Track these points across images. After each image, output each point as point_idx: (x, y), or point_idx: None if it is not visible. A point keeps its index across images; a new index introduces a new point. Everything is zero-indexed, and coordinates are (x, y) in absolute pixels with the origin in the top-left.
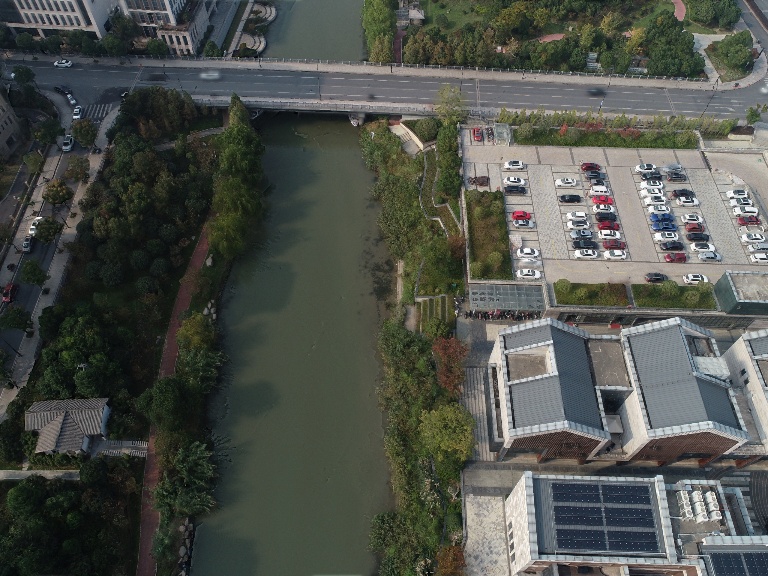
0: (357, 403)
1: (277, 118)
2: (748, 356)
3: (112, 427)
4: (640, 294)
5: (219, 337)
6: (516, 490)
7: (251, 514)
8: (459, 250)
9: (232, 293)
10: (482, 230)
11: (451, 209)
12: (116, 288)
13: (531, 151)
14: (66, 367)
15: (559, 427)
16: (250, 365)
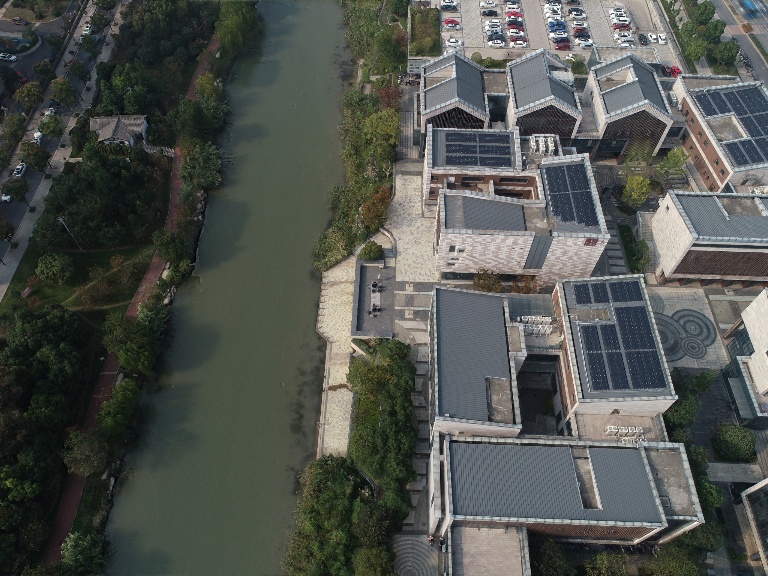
0: (324, 136)
1: None
2: (593, 79)
3: (150, 132)
4: None
5: (225, 99)
6: (425, 150)
7: (247, 191)
8: (403, 40)
9: (235, 77)
10: (421, 30)
11: (401, 25)
12: (149, 67)
13: None
14: (118, 93)
15: (453, 102)
16: (247, 115)
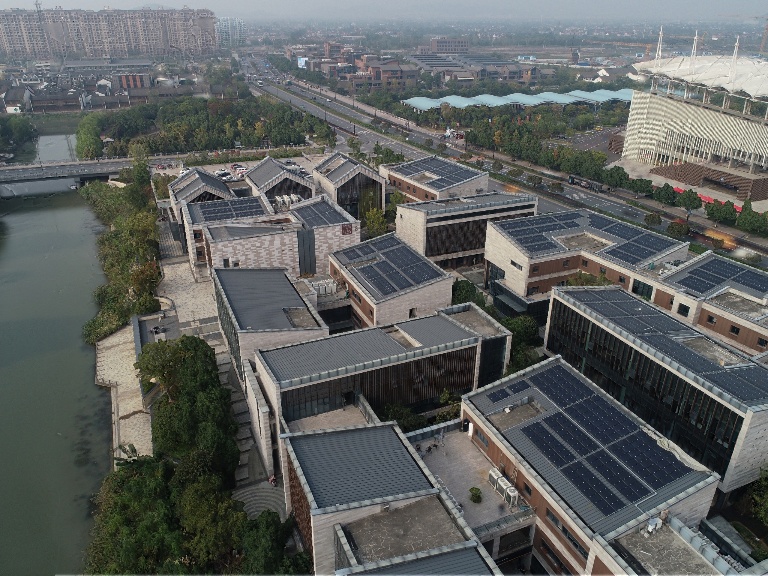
0: (82, 266)
1: (10, 200)
2: None
3: None
4: None
5: None
6: None
7: None
8: (149, 194)
9: None
10: None
11: None
12: None
13: None
14: None
15: (200, 186)
16: None
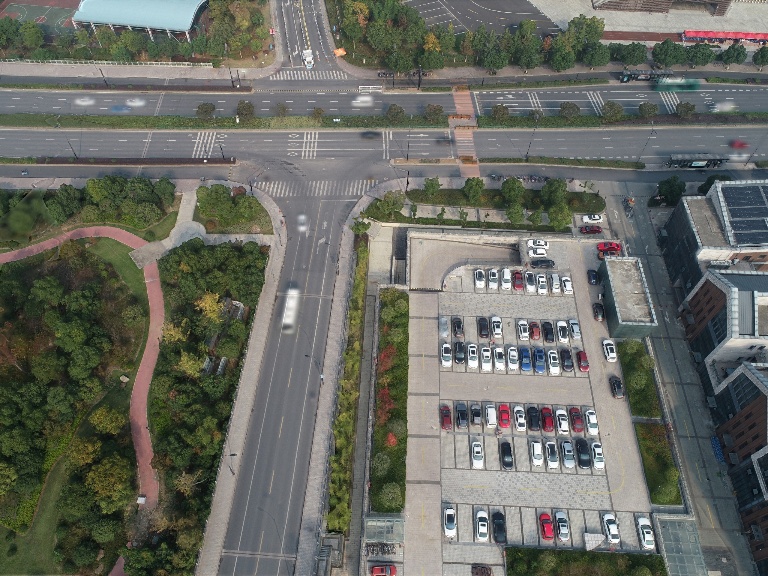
0: None
1: None
2: None
3: None
4: (647, 410)
5: None
6: None
7: None
8: None
9: None
10: None
11: None
12: None
13: (415, 491)
14: None
15: None
16: None
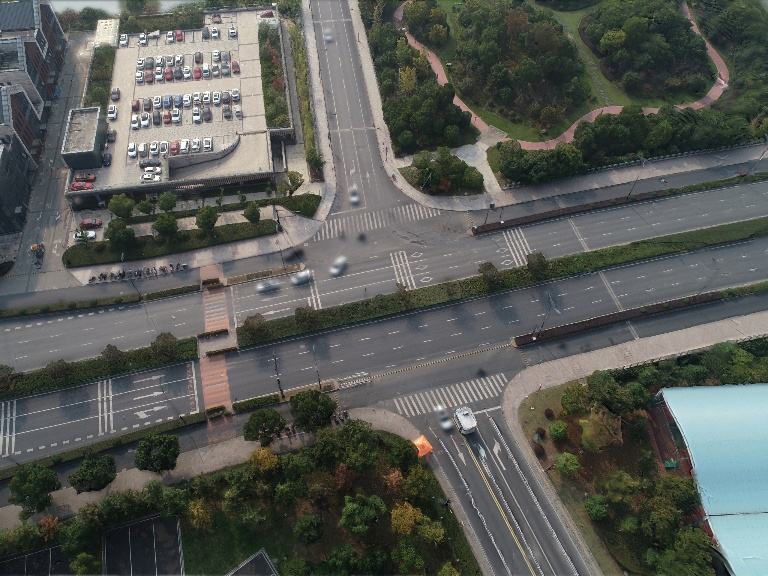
0: None
1: None
2: None
3: None
4: (100, 84)
5: None
6: None
7: None
8: (145, 11)
9: None
10: (166, 21)
11: None
12: None
13: (253, 41)
14: None
15: None
16: None
